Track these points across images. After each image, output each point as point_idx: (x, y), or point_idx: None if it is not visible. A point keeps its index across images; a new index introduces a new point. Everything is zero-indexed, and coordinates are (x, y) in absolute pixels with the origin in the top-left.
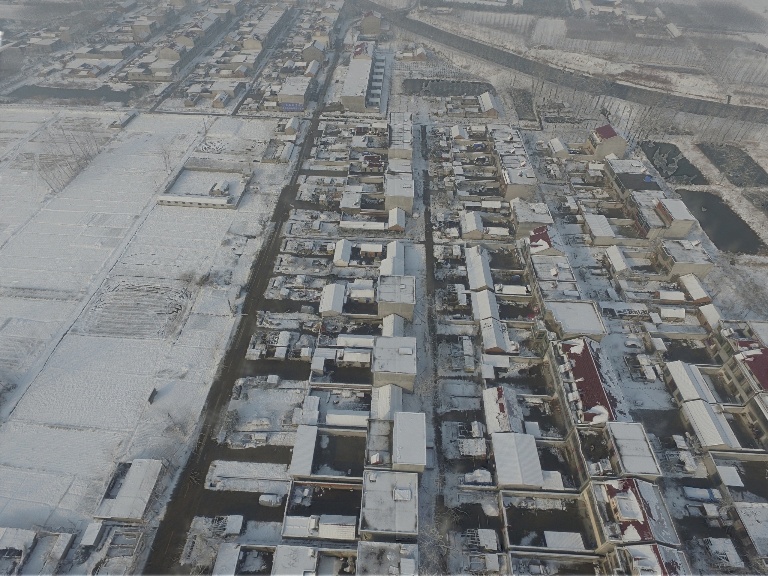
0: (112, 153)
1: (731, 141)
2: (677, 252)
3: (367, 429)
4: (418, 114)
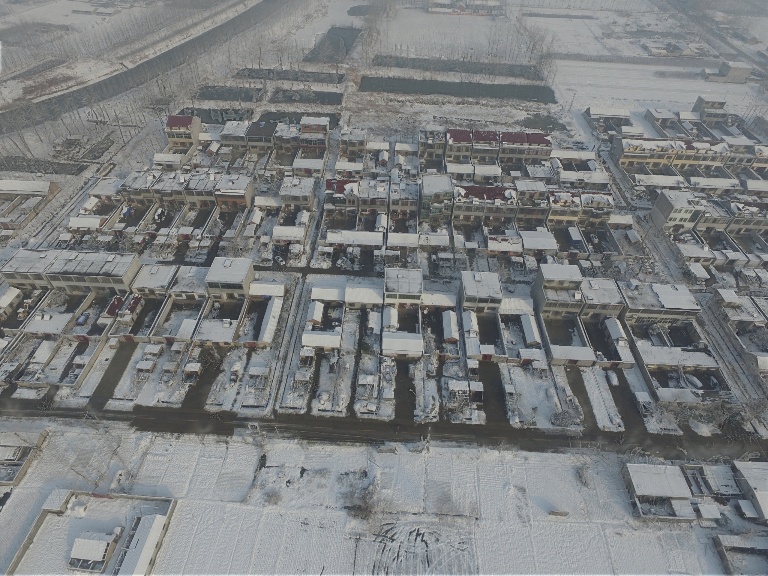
0: None
1: (197, 85)
2: (354, 137)
3: (555, 301)
4: None
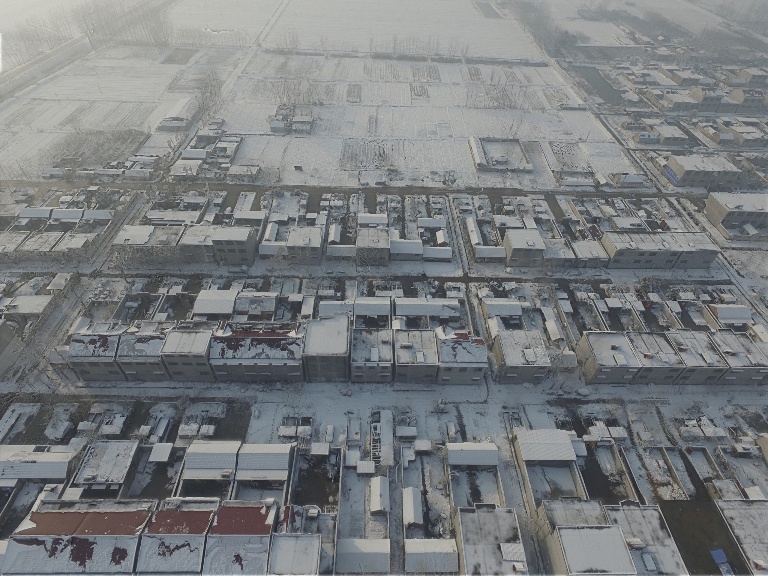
0: (524, 113)
1: None
2: (487, 522)
3: None
4: (764, 277)
